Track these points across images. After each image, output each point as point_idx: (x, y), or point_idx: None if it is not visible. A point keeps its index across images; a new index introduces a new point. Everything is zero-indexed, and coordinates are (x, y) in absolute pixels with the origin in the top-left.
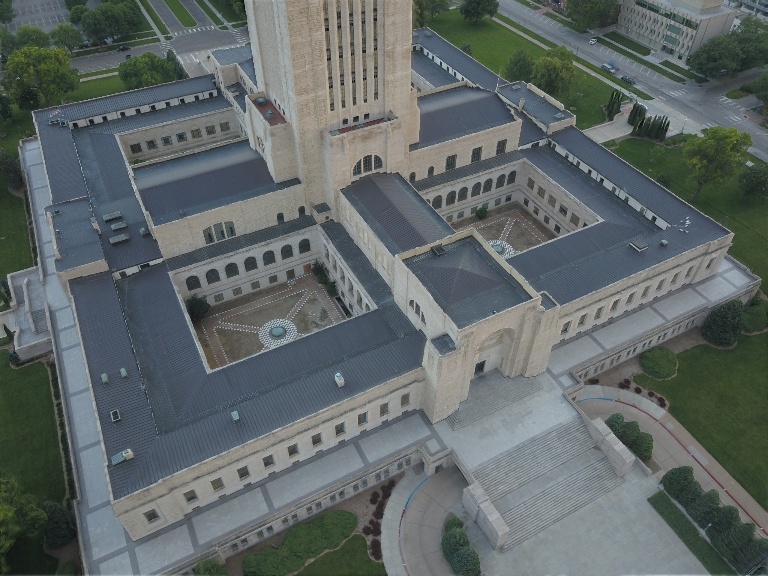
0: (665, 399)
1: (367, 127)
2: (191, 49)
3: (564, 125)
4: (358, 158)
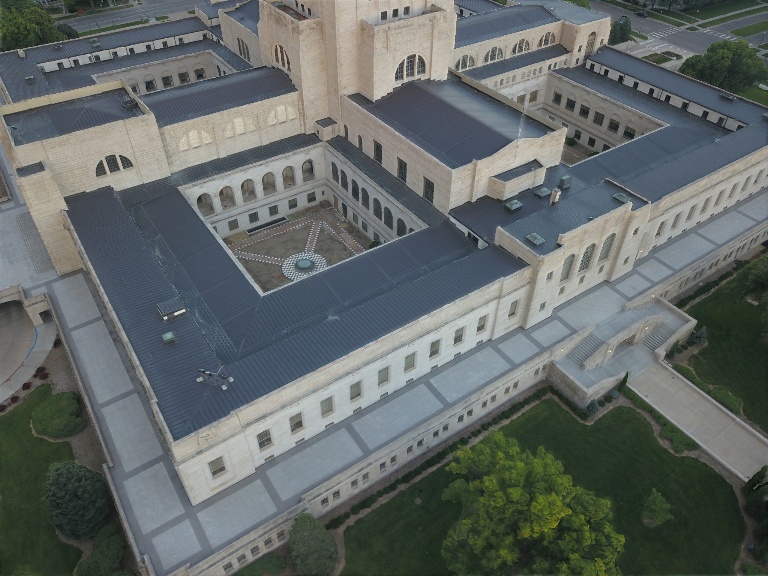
0: (1, 414)
1: (279, 10)
2: (678, 42)
3: (519, 252)
4: (275, 42)
